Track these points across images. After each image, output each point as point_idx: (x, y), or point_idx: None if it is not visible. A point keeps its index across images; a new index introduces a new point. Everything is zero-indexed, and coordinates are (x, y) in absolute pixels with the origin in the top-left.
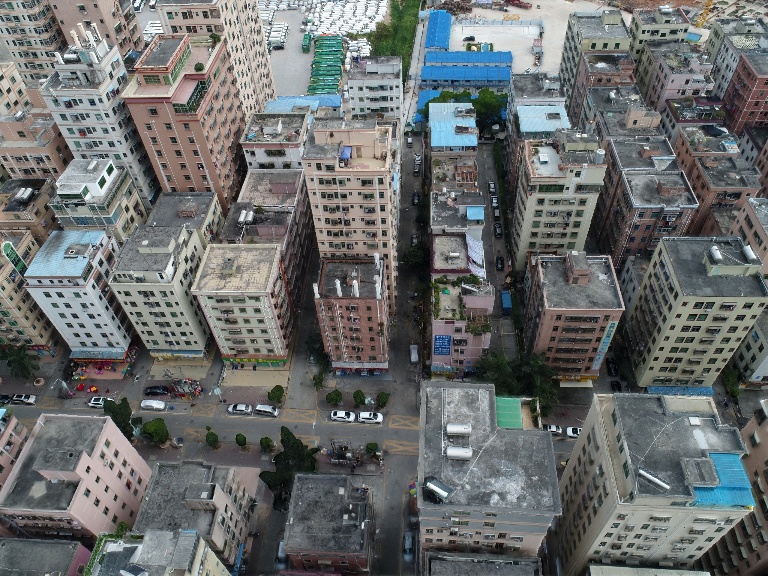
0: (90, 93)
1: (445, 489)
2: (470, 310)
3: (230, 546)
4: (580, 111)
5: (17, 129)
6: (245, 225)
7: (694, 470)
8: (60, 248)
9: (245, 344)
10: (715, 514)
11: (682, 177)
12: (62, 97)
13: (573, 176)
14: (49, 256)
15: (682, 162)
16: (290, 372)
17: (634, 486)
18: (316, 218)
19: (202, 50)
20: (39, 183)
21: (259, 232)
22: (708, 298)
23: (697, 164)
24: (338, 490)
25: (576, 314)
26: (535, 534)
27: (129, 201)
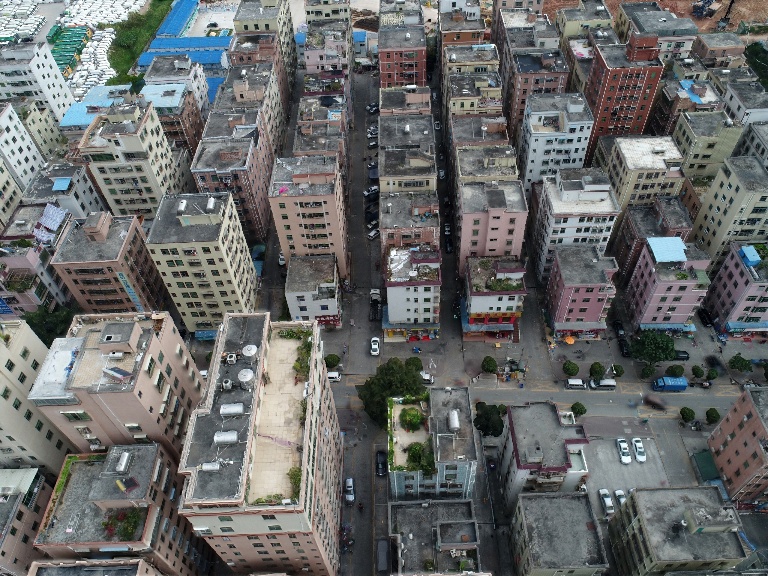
0: None
1: None
2: (12, 270)
3: None
4: None
5: None
6: None
7: None
8: None
9: None
10: None
11: None
12: None
13: (114, 145)
14: None
15: None
16: None
17: None
18: None
19: None
20: None
21: None
22: (167, 245)
23: None
24: None
25: (81, 267)
26: None
27: None
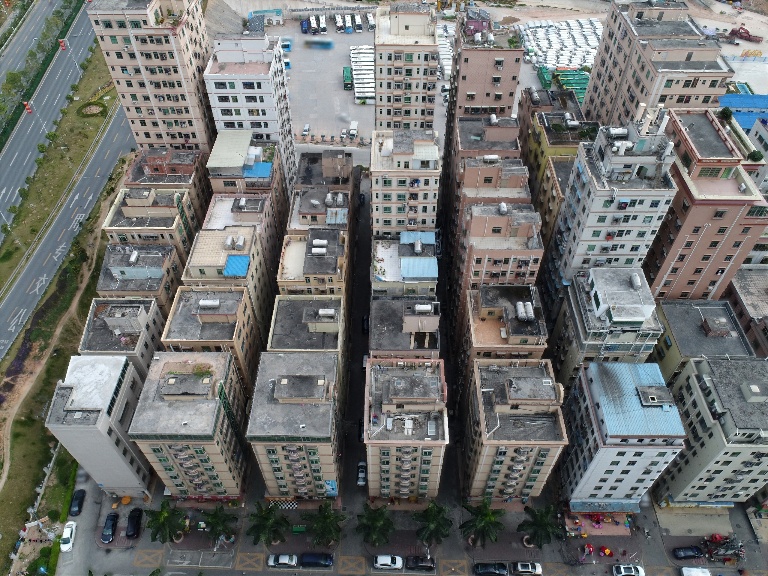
0: (662, 194)
1: None
2: None
3: None
4: None
5: (496, 224)
6: None
7: None
8: (625, 391)
9: None
10: None
11: None
12: (621, 197)
13: None
14: (620, 404)
15: None
16: None
17: None
18: None
19: None
20: (523, 292)
21: None
22: None
23: None
24: None
25: None
26: None
27: None
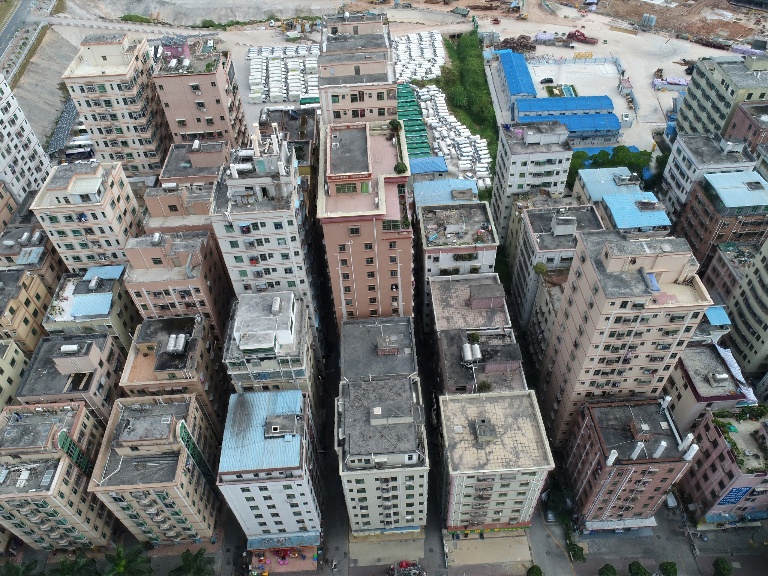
0: (279, 215)
1: None
2: None
3: None
4: None
5: (153, 255)
6: (473, 363)
7: None
8: (253, 423)
9: (486, 516)
10: None
11: None
12: (239, 221)
13: None
14: (243, 437)
15: None
16: (528, 537)
17: None
18: (588, 358)
19: (378, 140)
20: (187, 323)
21: (486, 369)
22: None
23: None
24: None
25: None
26: None
27: (308, 338)
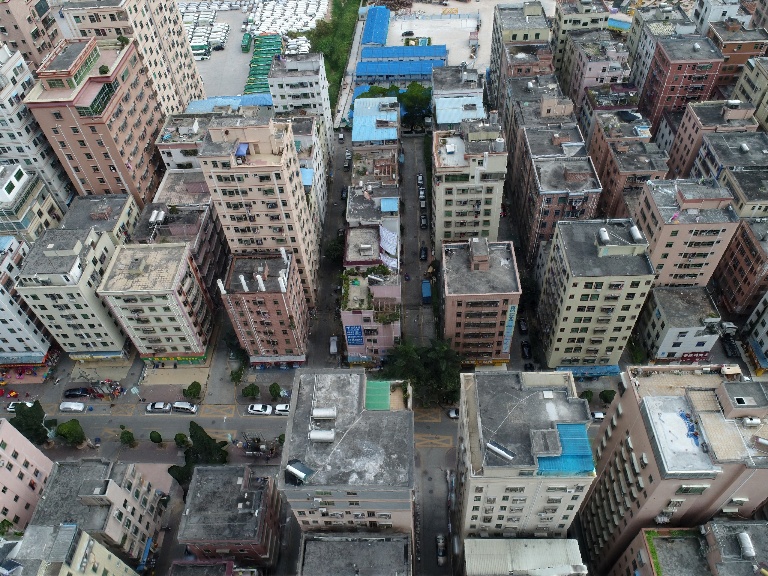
0: None
1: (305, 471)
2: (378, 300)
3: (131, 540)
4: (504, 101)
5: None
6: (156, 225)
7: (540, 441)
8: None
9: (161, 343)
10: (563, 482)
11: (589, 162)
12: None
13: (476, 165)
14: None
15: (599, 148)
16: (210, 369)
17: (482, 459)
18: (221, 215)
19: (111, 53)
20: None
21: (171, 231)
22: (596, 278)
23: (609, 149)
24: (236, 480)
25: (476, 299)
26: (400, 510)
27: (42, 206)
